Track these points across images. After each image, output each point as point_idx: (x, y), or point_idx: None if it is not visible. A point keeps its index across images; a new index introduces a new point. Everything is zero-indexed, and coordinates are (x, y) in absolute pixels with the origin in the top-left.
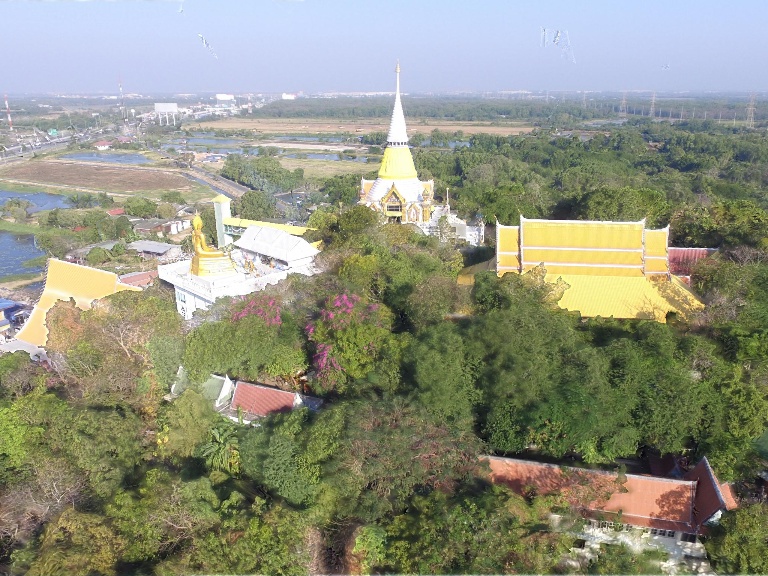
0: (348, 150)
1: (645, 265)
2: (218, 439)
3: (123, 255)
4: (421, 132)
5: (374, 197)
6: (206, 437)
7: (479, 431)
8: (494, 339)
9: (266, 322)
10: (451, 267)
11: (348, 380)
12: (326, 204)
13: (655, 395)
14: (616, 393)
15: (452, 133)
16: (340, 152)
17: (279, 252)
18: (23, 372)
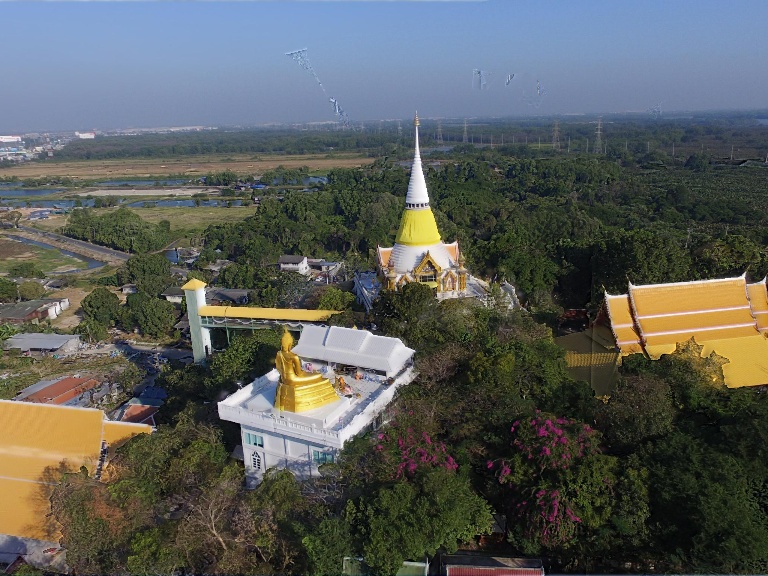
0: (198, 194)
1: None
2: None
3: (3, 358)
4: (271, 170)
5: (401, 268)
6: None
7: None
8: None
9: None
10: None
11: (575, 529)
12: (224, 261)
13: None
14: None
15: (297, 169)
16: (190, 197)
17: (373, 360)
18: None
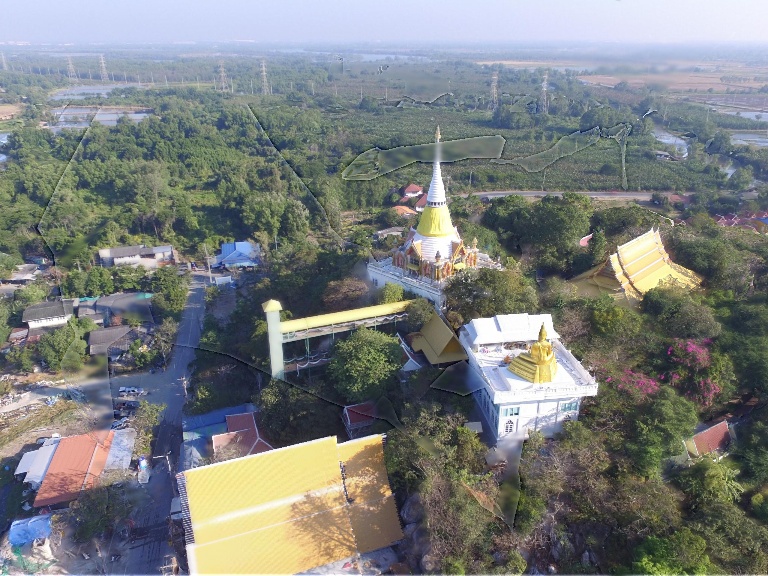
0: None
1: None
2: None
3: None
4: None
5: None
6: None
7: None
8: None
9: (655, 387)
10: None
11: None
12: (28, 266)
13: None
14: None
15: None
16: None
17: None
18: (481, 574)
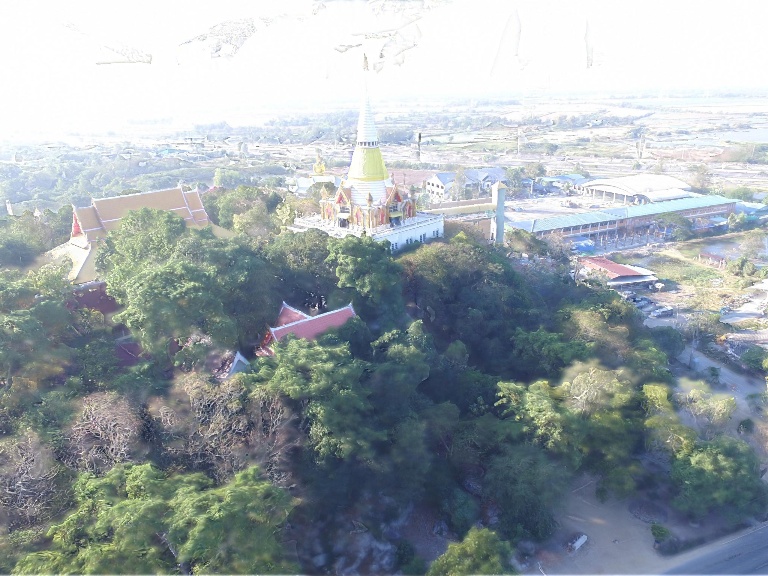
0: None
1: None
2: None
3: (756, 278)
4: None
5: None
6: None
7: None
8: None
9: None
10: None
11: None
12: None
13: None
14: None
15: None
16: None
17: None
18: None
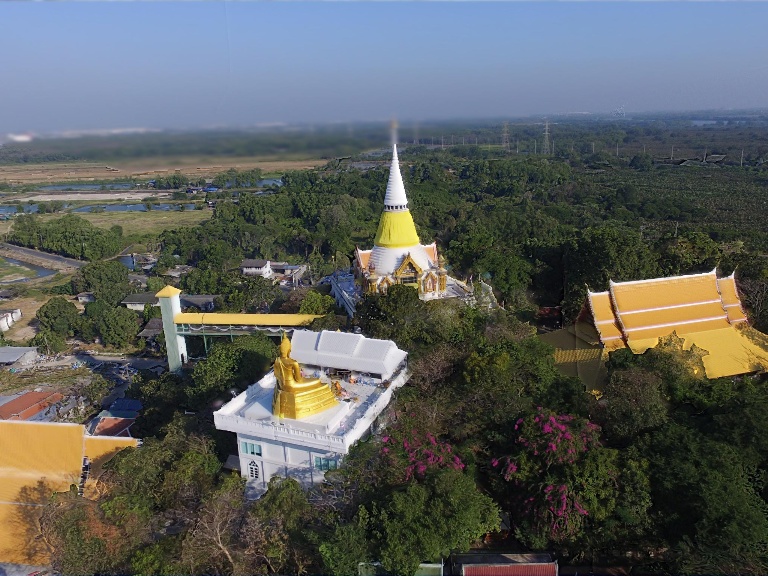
0: (149, 198)
1: None
2: None
3: None
4: (224, 173)
5: (382, 270)
6: None
7: None
8: None
9: None
10: None
11: (581, 522)
12: (183, 267)
13: None
14: None
15: (249, 171)
16: (140, 201)
17: (368, 364)
18: None
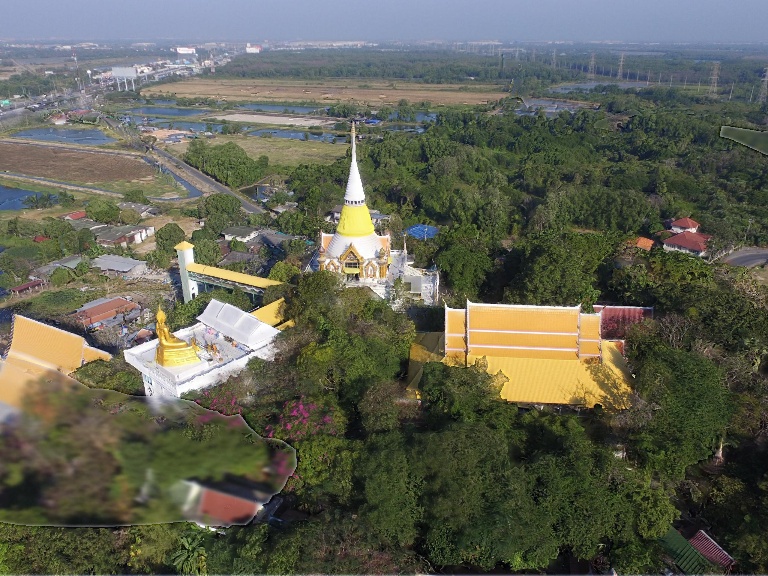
0: (314, 126)
1: (580, 348)
2: (187, 547)
3: (87, 274)
4: (388, 106)
5: (333, 253)
6: (176, 544)
7: (420, 546)
8: (434, 464)
9: None
10: (404, 340)
11: (305, 483)
12: (291, 204)
13: (573, 512)
14: (540, 511)
15: (420, 103)
16: (306, 129)
17: (240, 335)
18: None
